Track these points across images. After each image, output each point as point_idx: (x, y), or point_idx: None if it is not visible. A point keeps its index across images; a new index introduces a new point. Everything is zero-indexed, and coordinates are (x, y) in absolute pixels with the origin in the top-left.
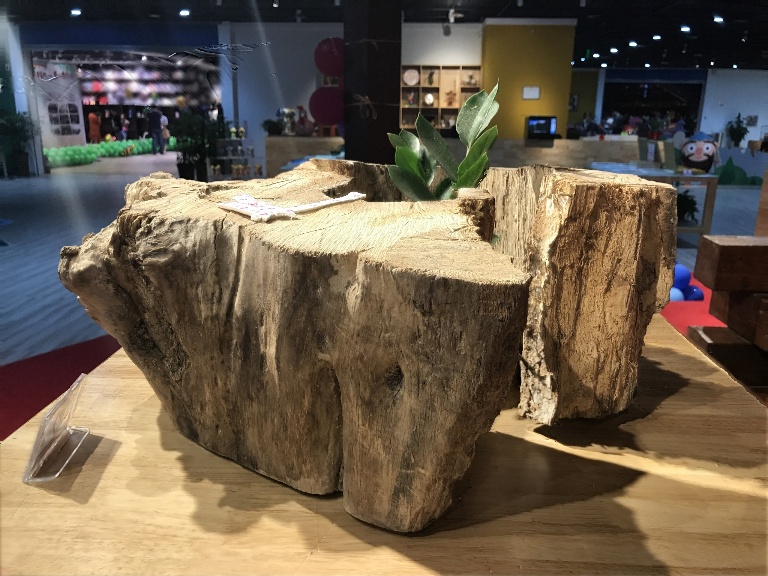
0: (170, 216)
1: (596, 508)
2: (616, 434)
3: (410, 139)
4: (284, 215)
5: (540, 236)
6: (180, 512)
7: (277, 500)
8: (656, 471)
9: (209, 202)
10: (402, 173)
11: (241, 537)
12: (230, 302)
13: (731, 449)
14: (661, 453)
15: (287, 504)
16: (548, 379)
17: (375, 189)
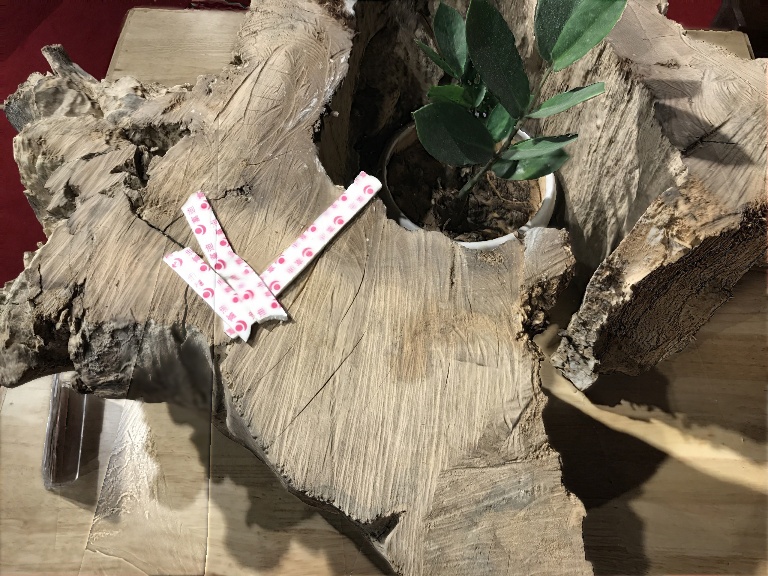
0: (105, 306)
1: (609, 520)
2: (650, 380)
3: (452, 23)
4: (270, 319)
5: (628, 259)
6: (212, 536)
7: (302, 513)
8: (678, 452)
9: (150, 234)
10: (437, 114)
11: (276, 575)
12: (218, 404)
13: (764, 408)
14: (690, 417)
15: (313, 519)
16: (591, 364)
17: (388, 15)
